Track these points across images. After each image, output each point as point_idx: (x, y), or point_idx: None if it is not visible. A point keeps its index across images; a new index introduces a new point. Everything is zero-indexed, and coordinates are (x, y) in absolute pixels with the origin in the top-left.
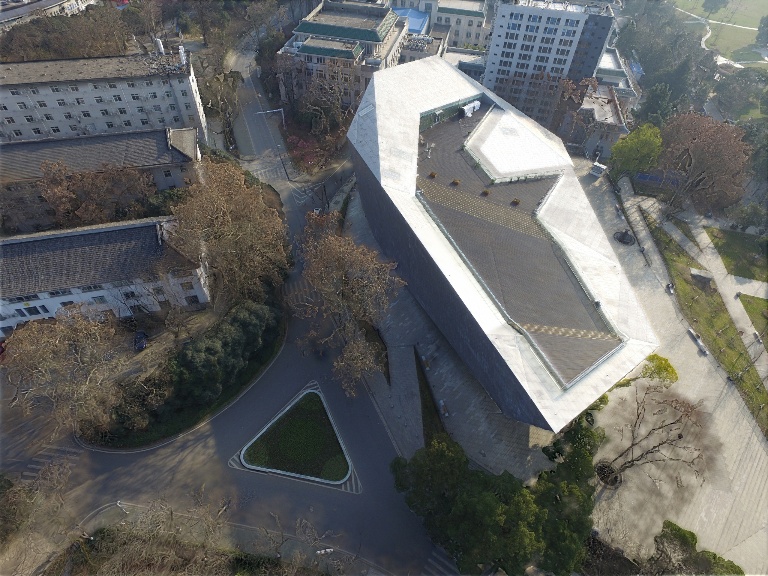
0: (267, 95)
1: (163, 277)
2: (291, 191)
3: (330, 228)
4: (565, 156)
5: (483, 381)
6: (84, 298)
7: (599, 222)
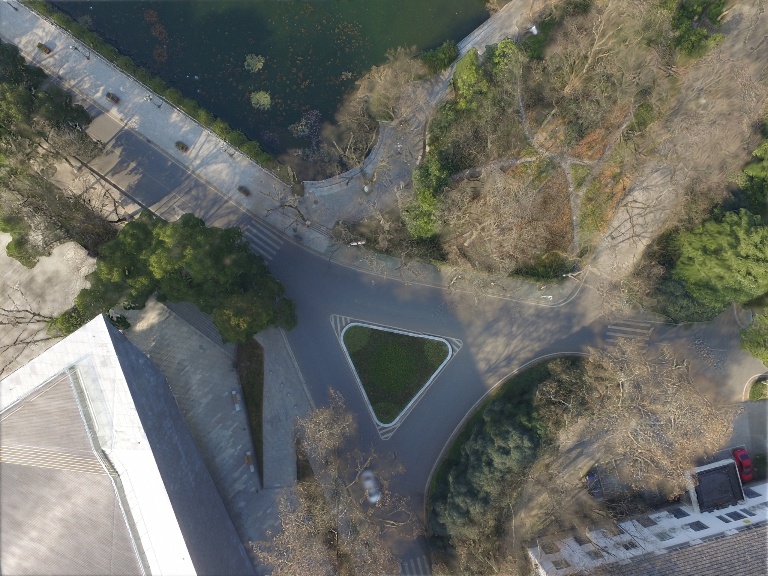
0: None
1: (596, 572)
2: None
3: None
4: None
5: (179, 416)
6: (683, 536)
7: None
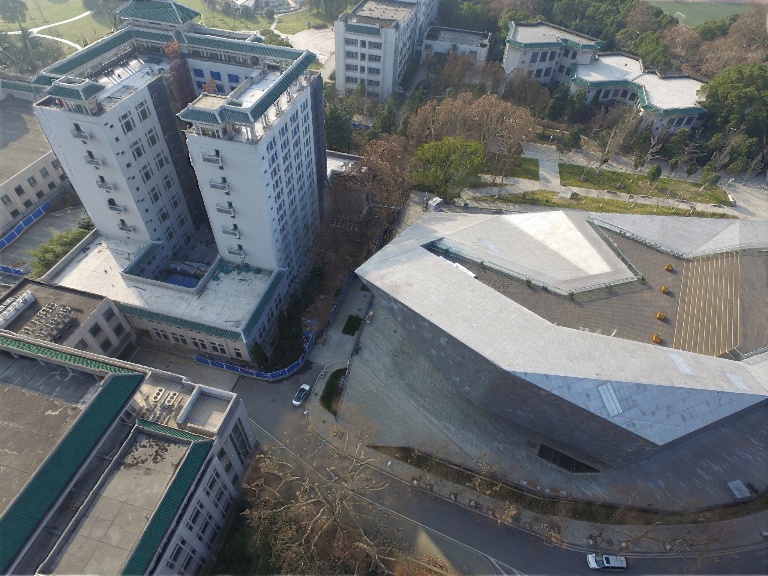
0: None
1: None
2: None
3: None
4: (483, 216)
5: None
6: None
7: None
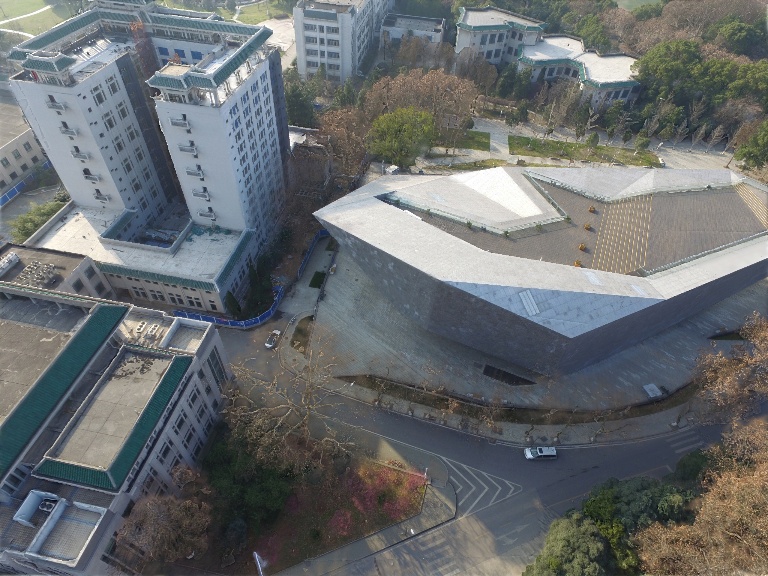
0: None
1: None
2: (487, 508)
3: None
4: None
5: None
6: None
7: None
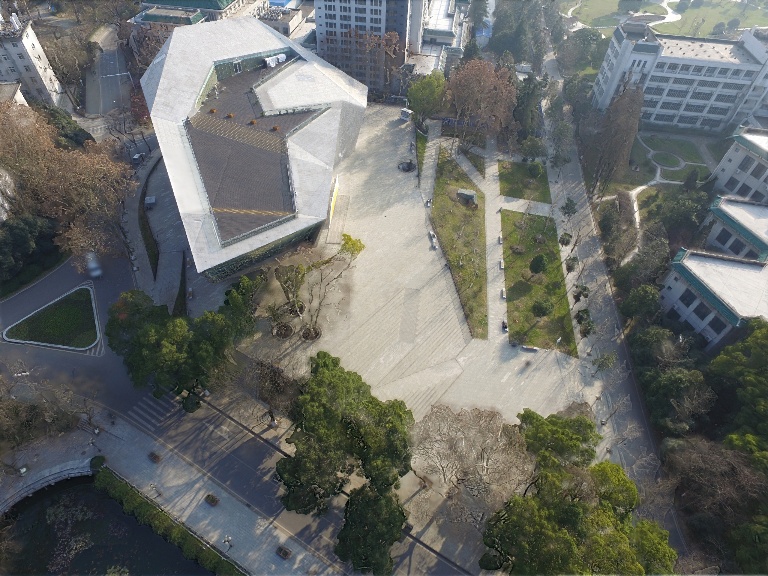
0: (127, 64)
1: None
2: (124, 141)
3: (106, 153)
4: (360, 99)
5: None
6: None
7: (391, 155)
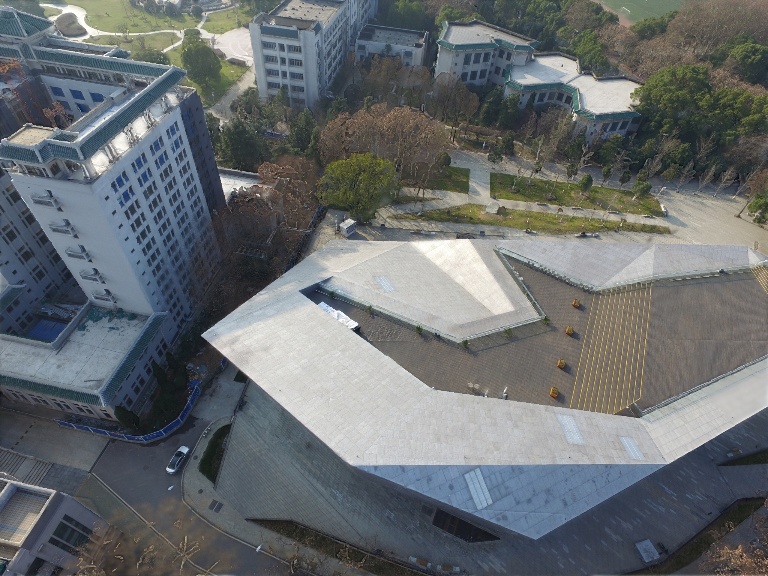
0: None
1: None
2: None
3: None
4: (389, 244)
5: None
6: None
7: None
